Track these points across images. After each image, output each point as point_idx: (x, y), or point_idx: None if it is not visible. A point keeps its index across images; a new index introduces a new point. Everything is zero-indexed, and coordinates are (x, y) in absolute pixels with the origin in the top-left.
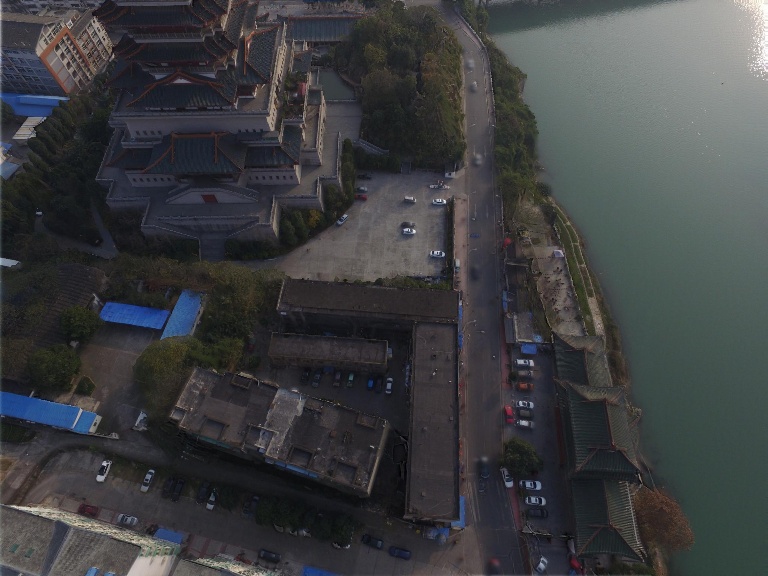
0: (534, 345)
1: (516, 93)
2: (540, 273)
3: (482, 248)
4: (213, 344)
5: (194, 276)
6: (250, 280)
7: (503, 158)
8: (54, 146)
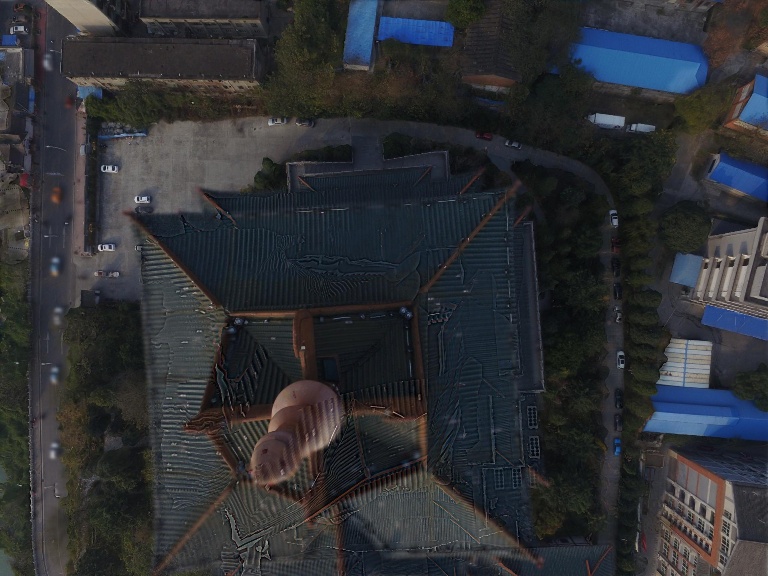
0: (4, 44)
1: (7, 483)
2: (1, 157)
3: (58, 180)
4: (319, 1)
5: (373, 103)
6: (284, 61)
7: (17, 315)
8: (634, 314)
